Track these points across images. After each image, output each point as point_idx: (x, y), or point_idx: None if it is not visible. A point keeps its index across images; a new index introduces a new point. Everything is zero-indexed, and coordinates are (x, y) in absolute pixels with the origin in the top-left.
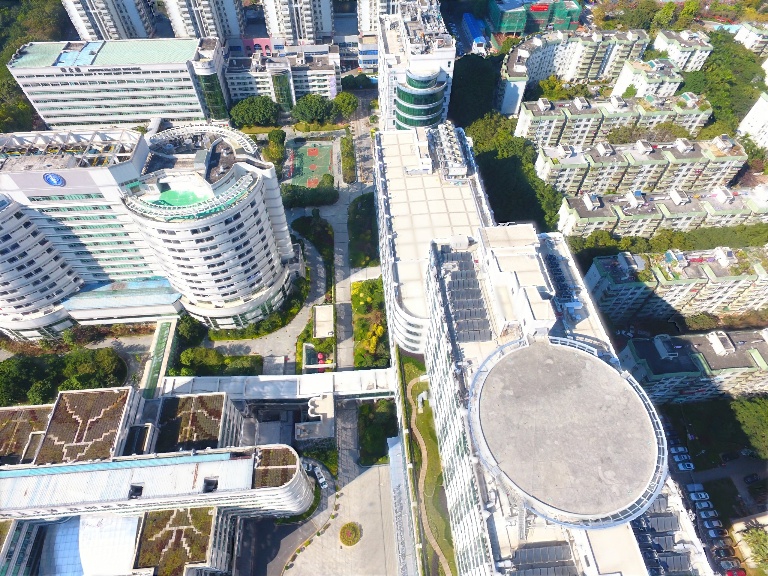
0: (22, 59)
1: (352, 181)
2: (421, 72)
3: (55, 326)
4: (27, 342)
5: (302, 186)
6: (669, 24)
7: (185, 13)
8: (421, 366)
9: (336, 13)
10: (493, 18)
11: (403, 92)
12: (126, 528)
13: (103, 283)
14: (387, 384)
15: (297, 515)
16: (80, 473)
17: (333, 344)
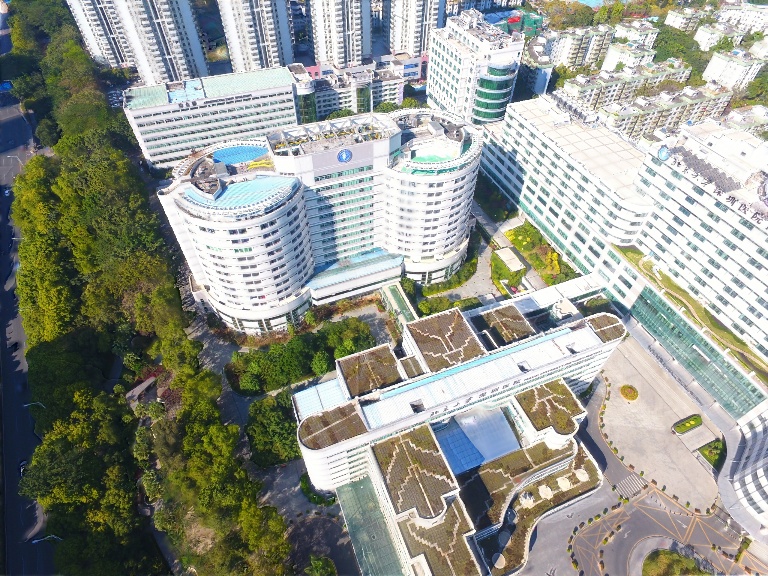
0: (133, 102)
1: None
2: (500, 63)
3: (299, 309)
4: (269, 333)
5: None
6: (608, 22)
7: (254, 49)
8: (638, 252)
9: None
10: None
11: (487, 81)
12: (497, 417)
13: (329, 264)
14: (597, 284)
15: (584, 391)
16: (472, 368)
17: (523, 275)
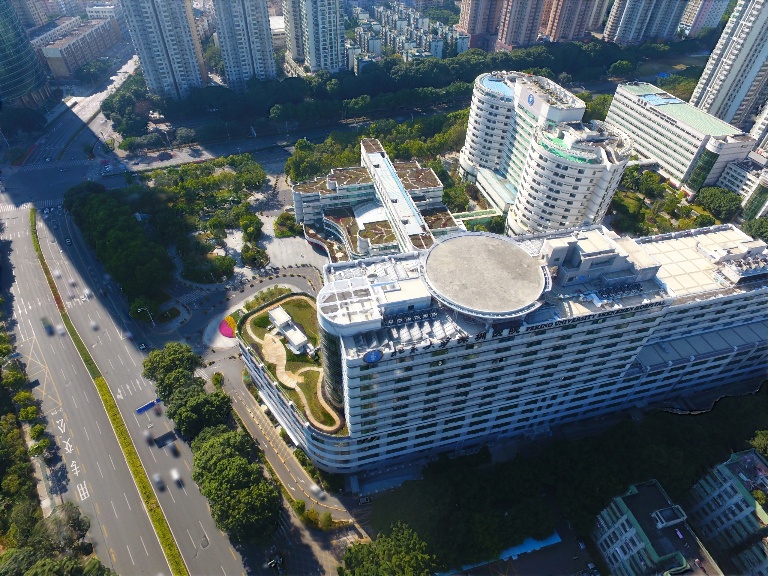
0: (631, 86)
1: None
2: None
3: (470, 176)
4: None
5: None
6: None
7: (767, 119)
8: None
9: None
10: None
11: None
12: None
13: (503, 176)
14: None
15: None
16: (397, 184)
17: None
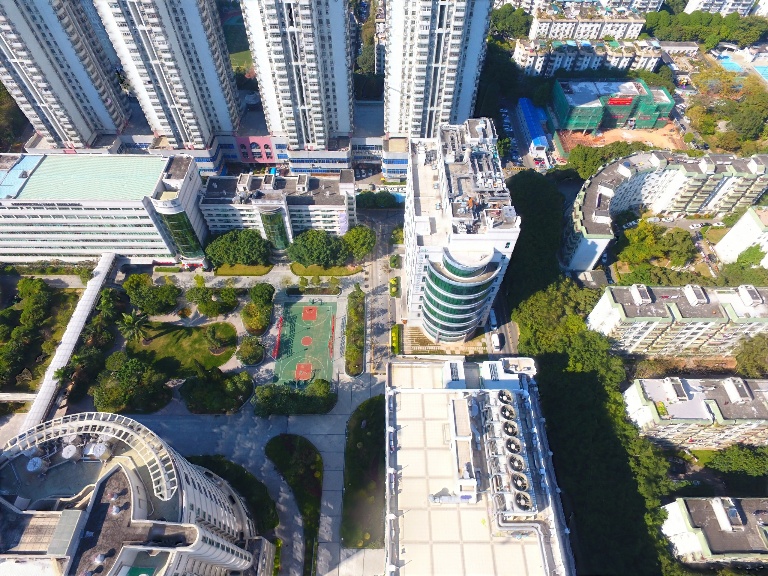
0: None
1: (357, 373)
2: (465, 254)
3: None
4: None
5: (286, 387)
6: None
7: (159, 111)
8: None
9: (358, 100)
10: (558, 110)
11: (437, 276)
12: None
13: None
14: None
15: None
16: None
17: None
